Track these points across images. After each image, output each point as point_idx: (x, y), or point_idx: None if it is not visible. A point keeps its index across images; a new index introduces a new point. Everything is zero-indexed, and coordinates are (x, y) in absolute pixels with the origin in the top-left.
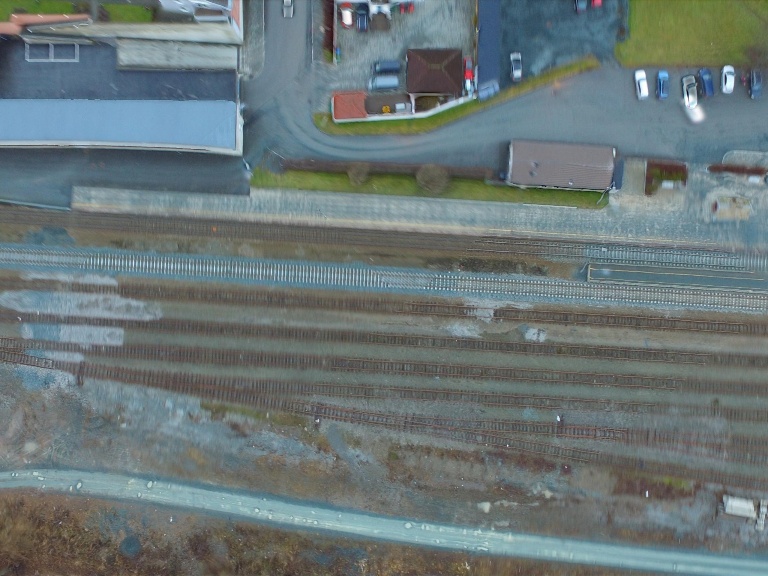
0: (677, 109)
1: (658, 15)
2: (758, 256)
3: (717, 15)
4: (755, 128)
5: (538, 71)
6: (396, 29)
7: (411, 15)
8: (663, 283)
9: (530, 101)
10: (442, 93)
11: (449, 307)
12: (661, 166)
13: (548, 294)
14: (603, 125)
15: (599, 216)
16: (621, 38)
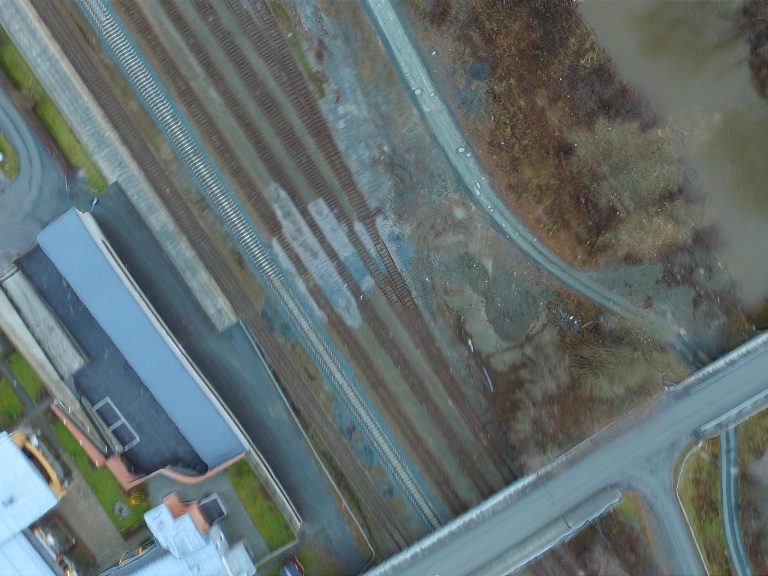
0: None
1: None
2: None
3: None
4: None
5: None
6: None
7: None
8: None
9: None
10: None
11: None
12: None
13: None
14: None
15: None
16: None
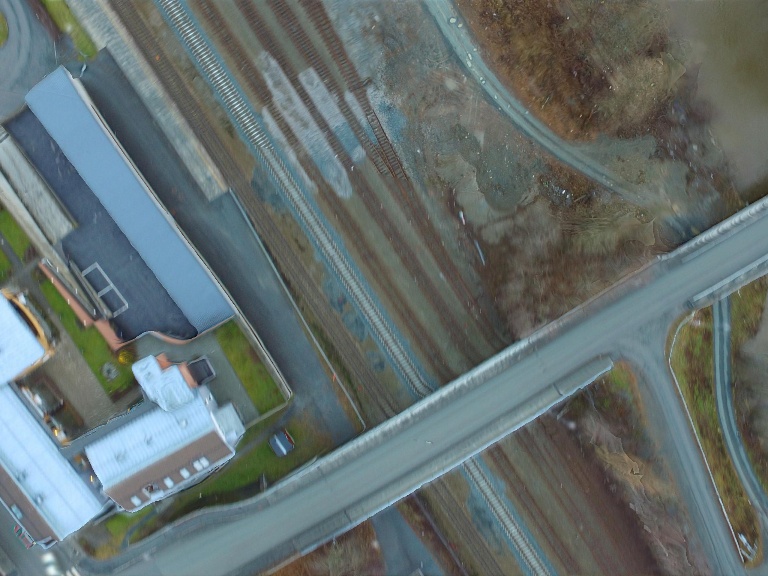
0: None
1: None
2: None
3: None
4: None
5: None
6: None
7: None
8: None
9: None
10: None
11: None
12: None
13: None
14: None
15: None
16: None
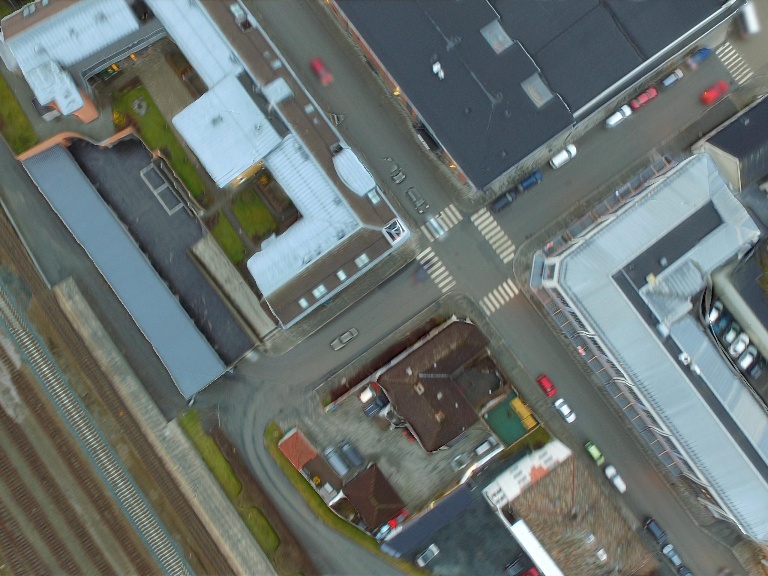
0: None
1: None
2: None
3: None
4: None
5: (438, 573)
6: (389, 436)
7: (408, 440)
8: None
9: None
10: None
11: None
12: None
13: None
14: None
15: None
16: None
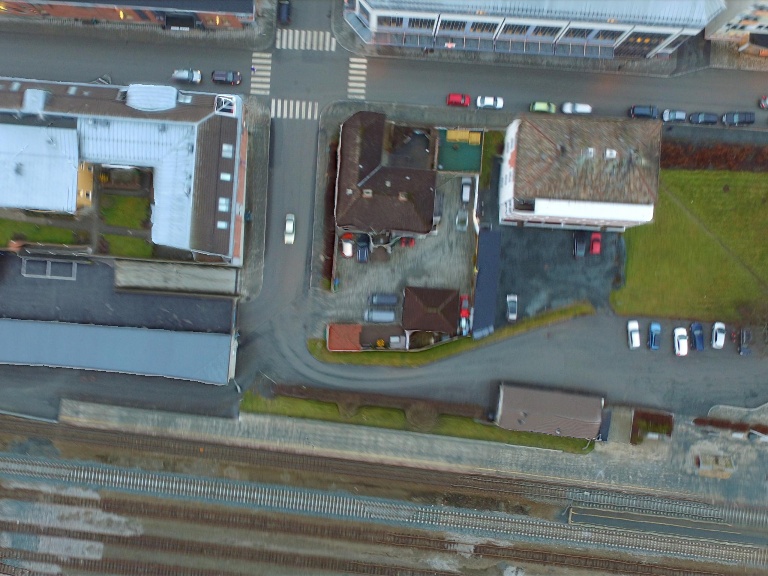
0: (667, 359)
1: (654, 265)
2: (737, 509)
3: (712, 268)
4: (742, 384)
5: (533, 312)
6: (396, 260)
7: (411, 248)
8: (642, 531)
9: (523, 341)
10: (437, 331)
11: (430, 540)
12: (648, 416)
13: (529, 533)
14: (594, 371)
15: (584, 461)
16: (617, 286)
